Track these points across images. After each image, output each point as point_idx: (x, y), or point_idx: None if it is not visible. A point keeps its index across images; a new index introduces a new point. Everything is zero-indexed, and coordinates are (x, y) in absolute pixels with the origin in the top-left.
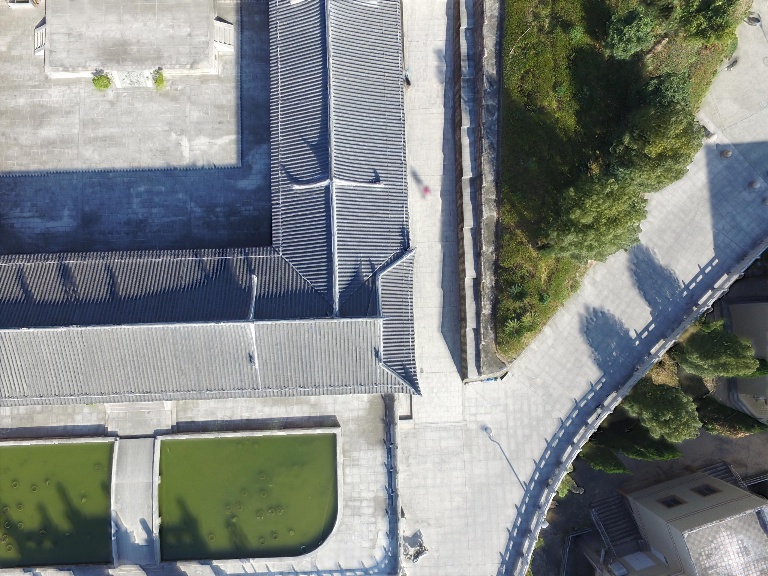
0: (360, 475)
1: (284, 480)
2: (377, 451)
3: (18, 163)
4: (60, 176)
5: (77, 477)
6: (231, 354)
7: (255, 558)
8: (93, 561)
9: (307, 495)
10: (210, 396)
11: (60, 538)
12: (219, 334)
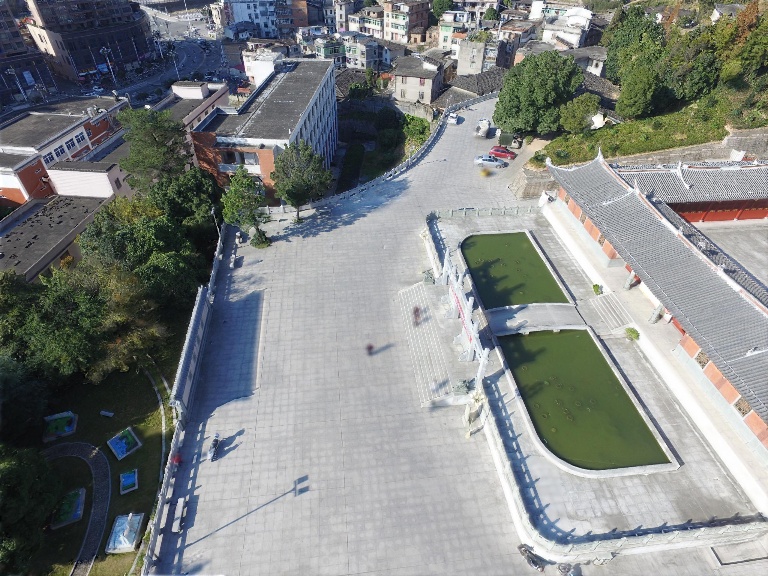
0: (639, 495)
1: (598, 420)
2: (674, 512)
3: (724, 245)
4: (735, 262)
5: (535, 289)
6: (746, 336)
7: (523, 400)
8: (482, 300)
9: (594, 441)
10: (691, 331)
11: (491, 284)
12: (759, 324)
